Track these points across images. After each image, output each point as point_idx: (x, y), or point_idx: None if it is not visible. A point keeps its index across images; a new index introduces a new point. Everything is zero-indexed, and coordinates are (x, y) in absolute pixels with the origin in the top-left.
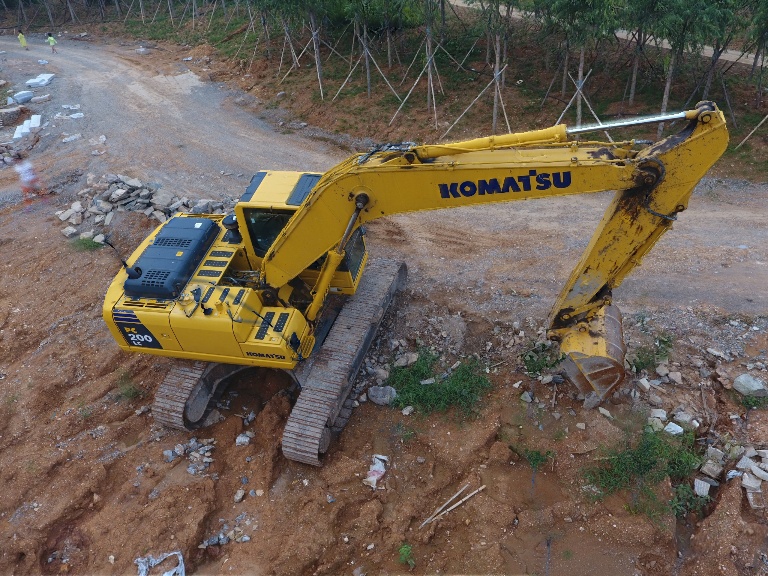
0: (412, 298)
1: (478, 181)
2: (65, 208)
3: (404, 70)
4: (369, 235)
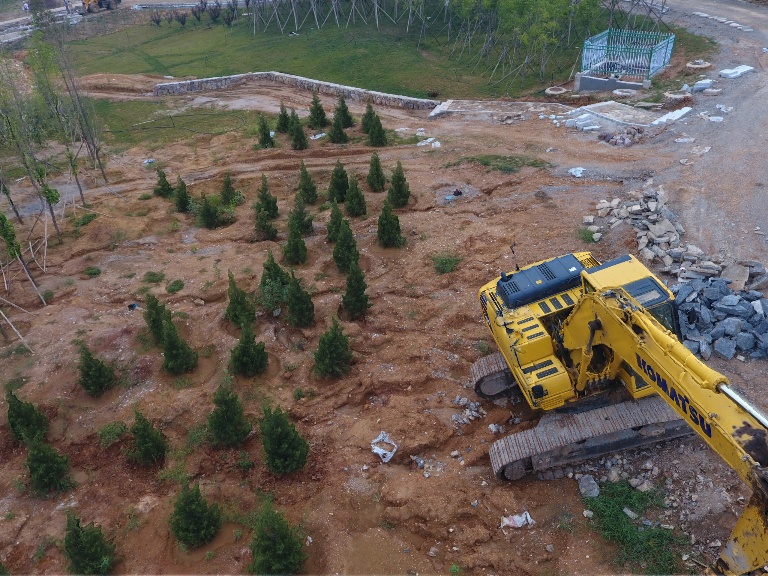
0: None
1: (656, 372)
2: (609, 199)
3: None
4: None
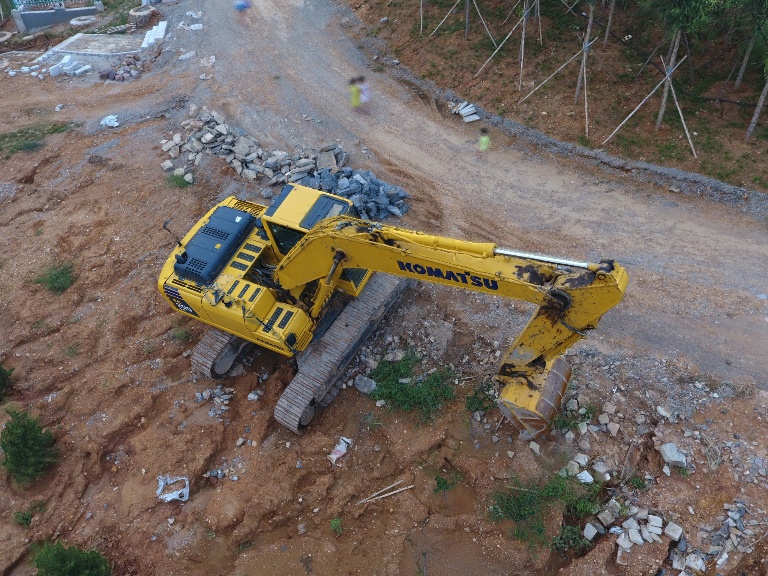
0: (419, 295)
1: (426, 267)
2: (168, 138)
3: (512, 5)
4: (410, 214)
